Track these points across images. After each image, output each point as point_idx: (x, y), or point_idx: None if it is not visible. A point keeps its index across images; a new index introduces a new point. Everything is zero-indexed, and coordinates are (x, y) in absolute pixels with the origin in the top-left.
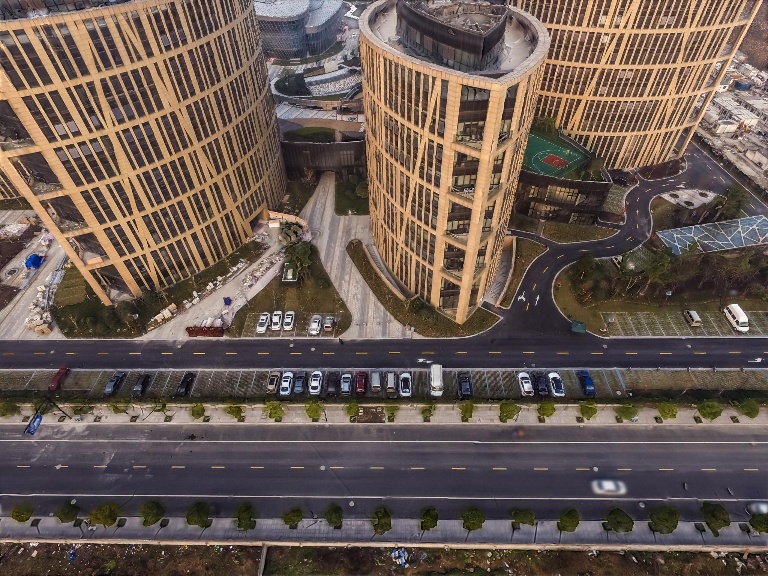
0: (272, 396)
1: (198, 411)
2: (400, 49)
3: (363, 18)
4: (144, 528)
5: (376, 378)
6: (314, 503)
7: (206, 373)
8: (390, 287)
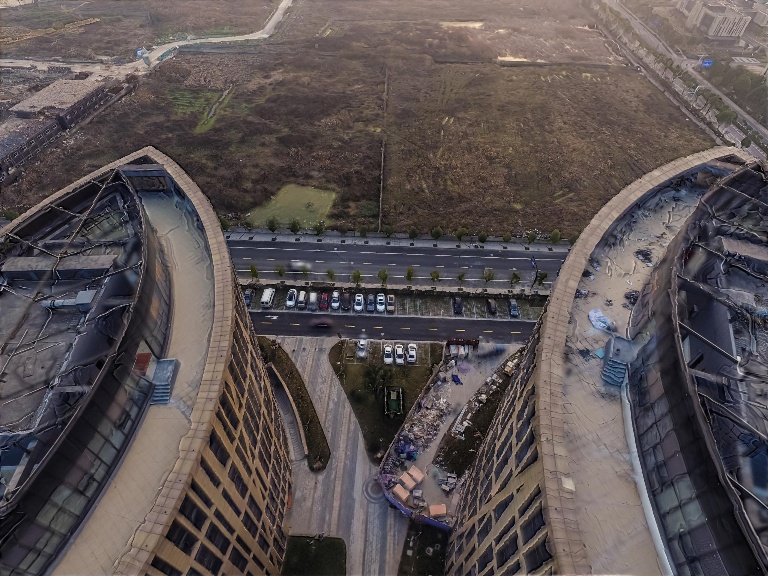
0: (389, 291)
1: (434, 272)
2: (193, 263)
3: (205, 408)
4: (445, 244)
5: (313, 297)
6: (356, 250)
7: (447, 315)
8: (285, 384)
